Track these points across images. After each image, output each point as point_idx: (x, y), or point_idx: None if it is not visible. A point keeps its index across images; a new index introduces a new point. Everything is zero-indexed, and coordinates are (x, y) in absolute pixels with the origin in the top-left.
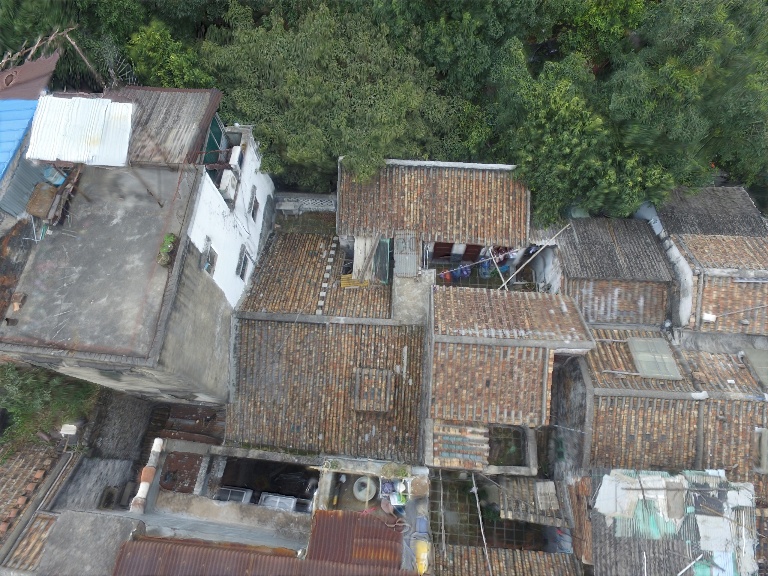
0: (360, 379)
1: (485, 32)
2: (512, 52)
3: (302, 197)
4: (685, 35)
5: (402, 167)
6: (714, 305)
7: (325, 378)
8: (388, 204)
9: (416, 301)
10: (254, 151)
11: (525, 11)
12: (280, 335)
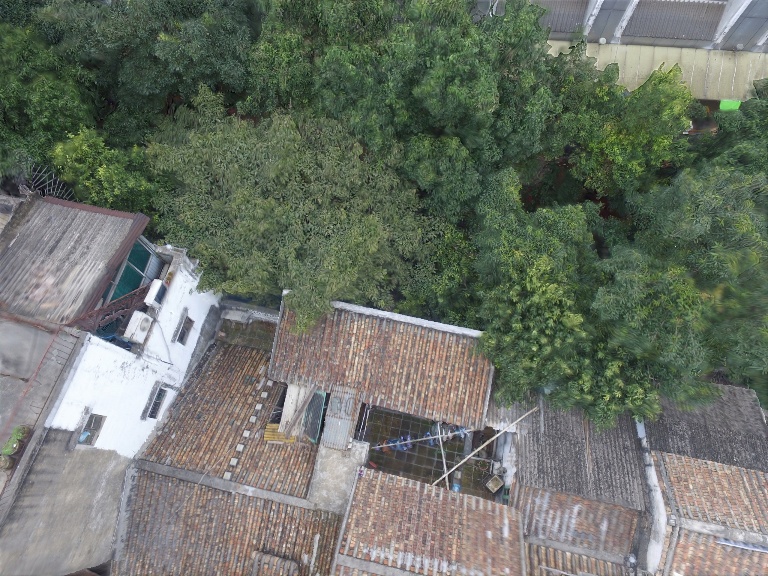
0: (259, 567)
1: (480, 154)
2: (503, 188)
3: (251, 309)
4: (697, 236)
5: (352, 312)
6: (688, 564)
7: (223, 553)
8: (330, 352)
9: (339, 481)
10: (188, 273)
11: (528, 138)
12: (180, 494)
